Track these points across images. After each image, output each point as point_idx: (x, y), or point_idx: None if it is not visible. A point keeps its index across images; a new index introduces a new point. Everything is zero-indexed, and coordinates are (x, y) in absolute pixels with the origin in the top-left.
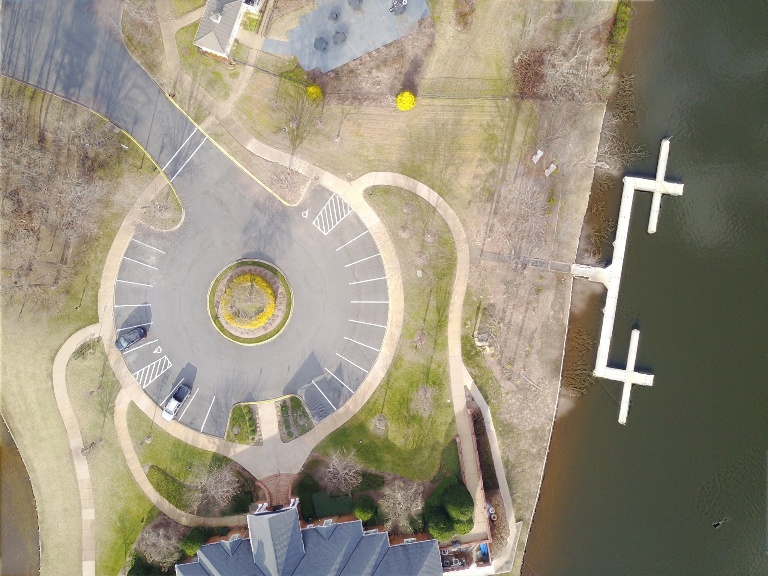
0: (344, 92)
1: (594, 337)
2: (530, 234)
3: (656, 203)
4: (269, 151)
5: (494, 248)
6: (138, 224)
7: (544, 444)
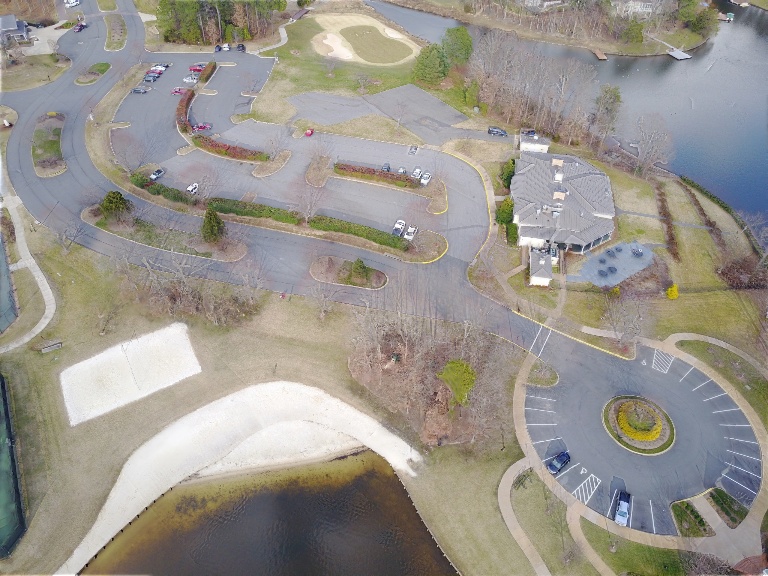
0: (630, 294)
1: None
2: None
3: None
4: (598, 331)
5: None
6: (526, 386)
7: None
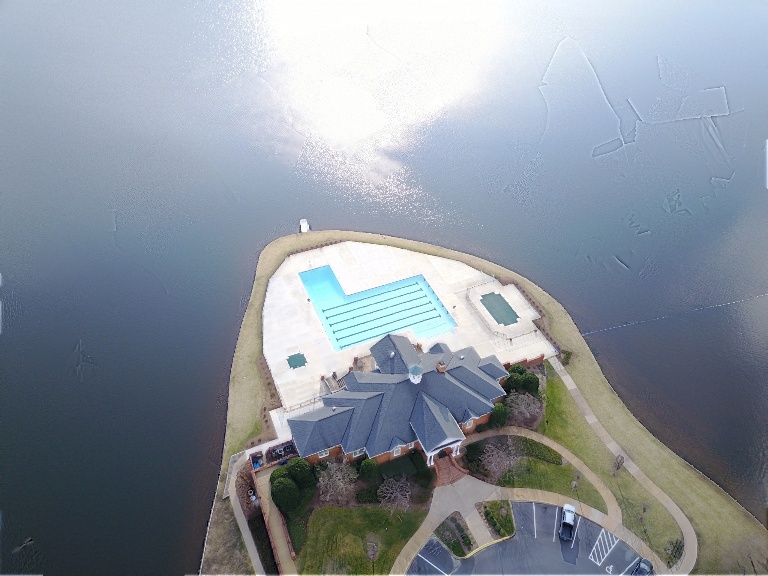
0: None
1: None
2: None
3: None
4: None
5: None
6: None
7: None
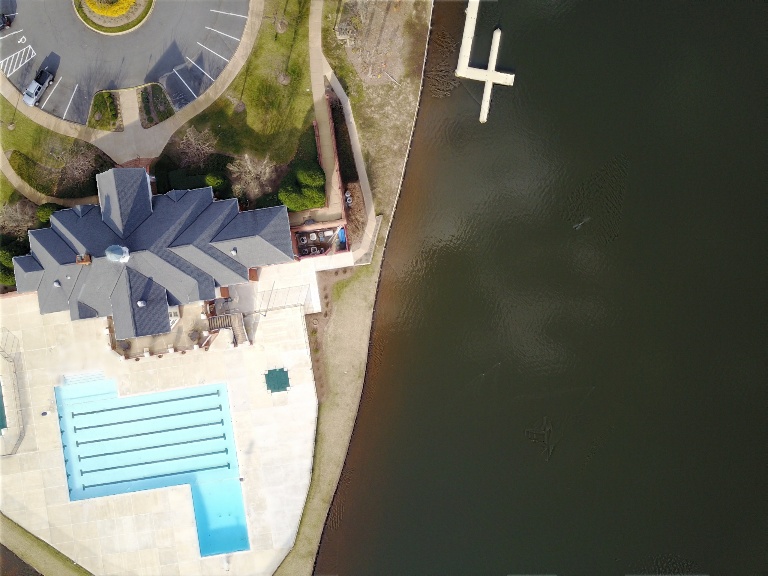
0: None
1: (457, 38)
2: None
3: None
4: None
5: None
6: None
7: (405, 141)
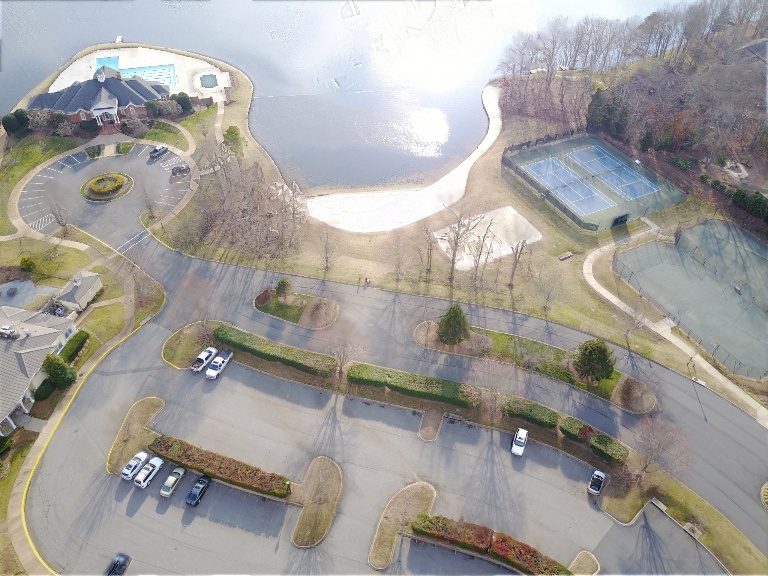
0: (7, 272)
1: None
2: None
3: None
4: (74, 246)
5: None
6: None
7: None
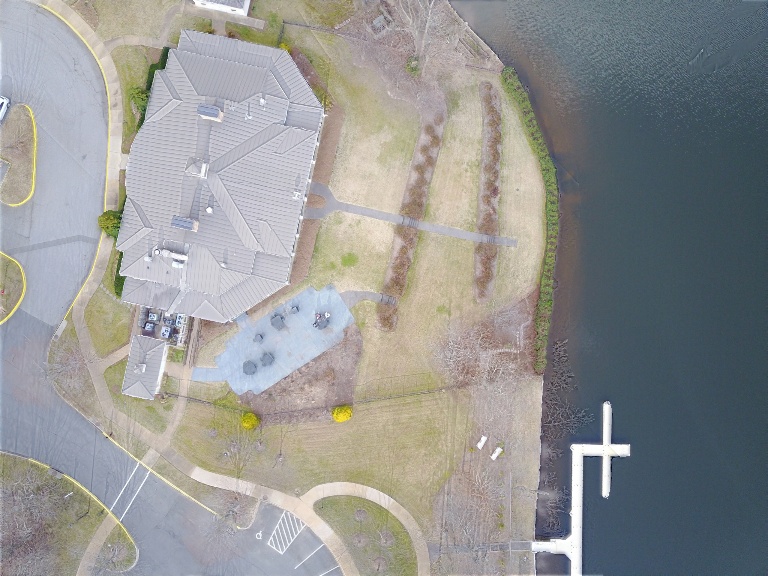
0: (280, 411)
1: None
2: (486, 519)
3: (607, 467)
4: (214, 477)
5: (452, 540)
6: (94, 568)
7: None
